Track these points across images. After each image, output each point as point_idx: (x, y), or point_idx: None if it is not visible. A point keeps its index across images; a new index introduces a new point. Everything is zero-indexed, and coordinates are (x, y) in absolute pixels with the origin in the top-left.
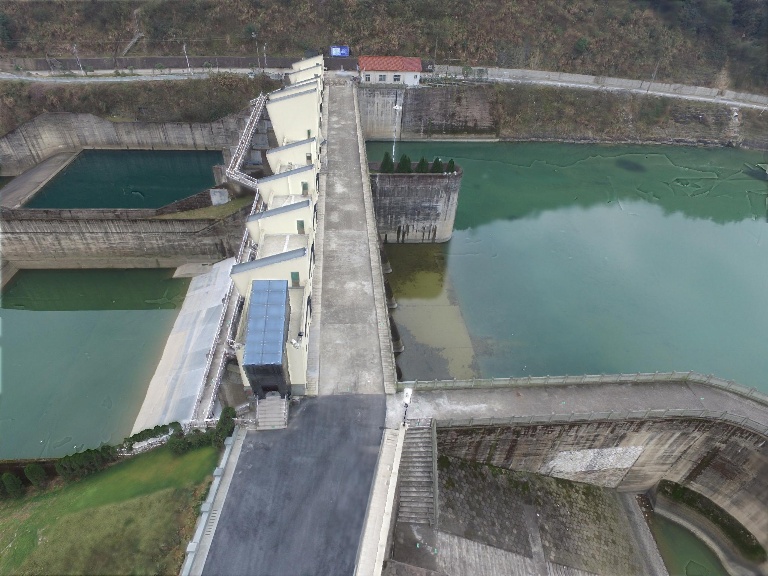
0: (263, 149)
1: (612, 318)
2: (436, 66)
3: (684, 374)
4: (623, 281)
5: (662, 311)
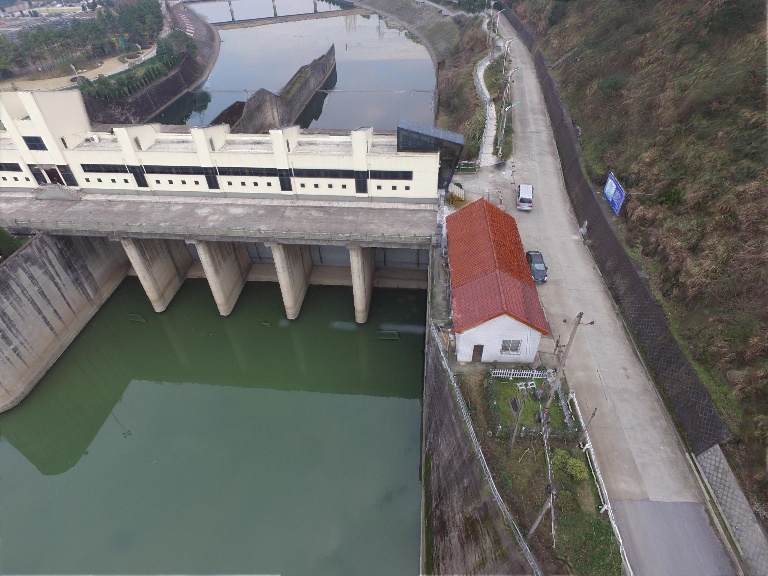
0: None
1: None
2: (719, 454)
3: None
4: None
5: None
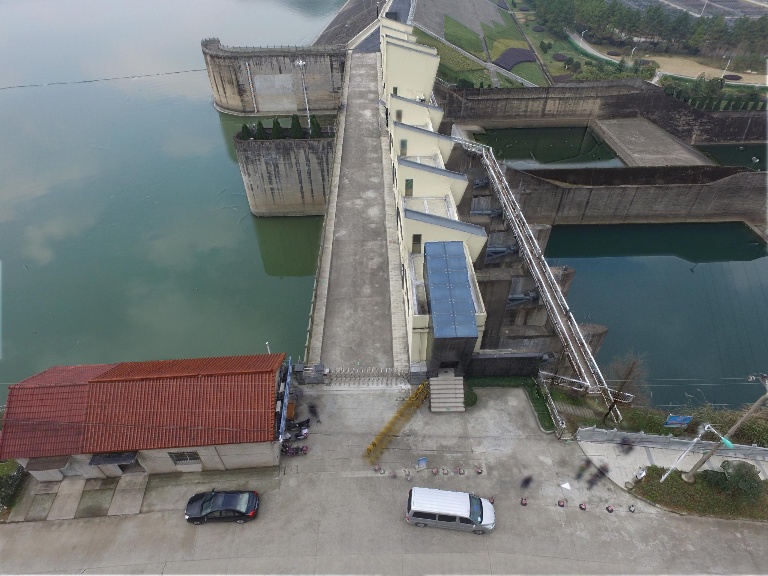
0: None
1: (176, 159)
2: None
3: (233, 53)
4: (129, 178)
5: (132, 161)
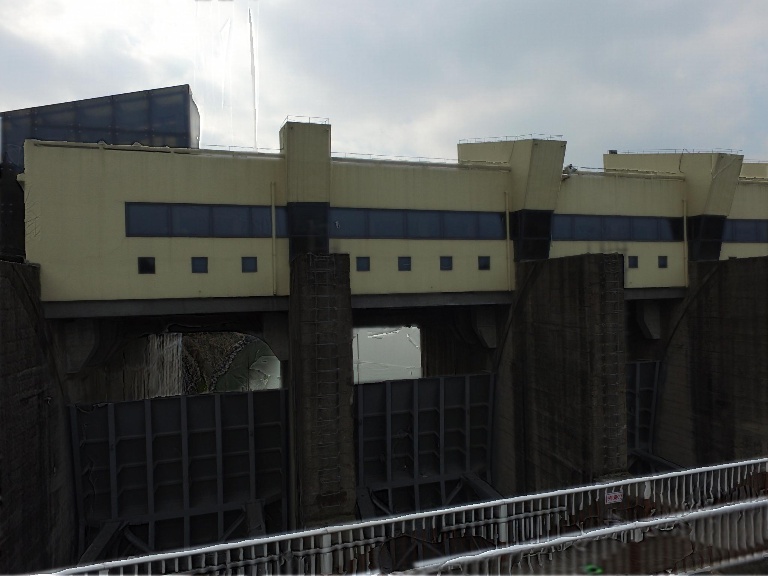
0: None
1: None
2: None
3: None
4: None
5: None
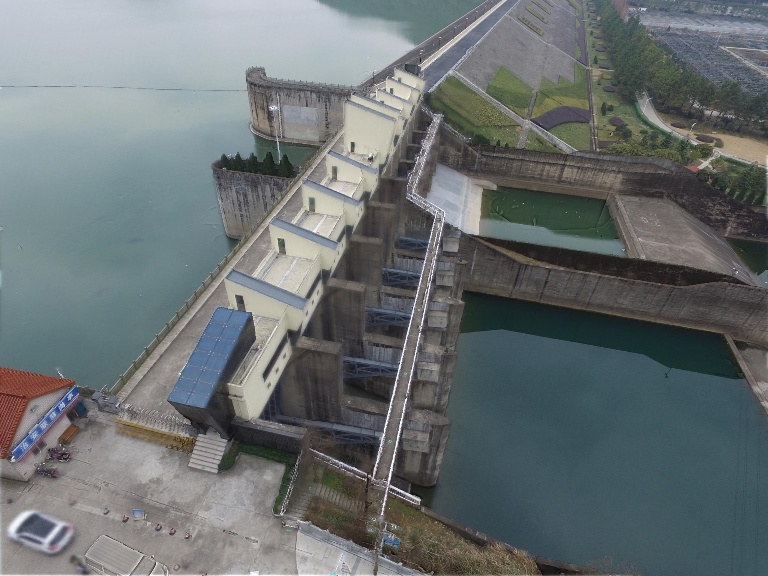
0: (405, 179)
1: (192, 171)
2: None
3: (267, 83)
4: None
5: (155, 167)
